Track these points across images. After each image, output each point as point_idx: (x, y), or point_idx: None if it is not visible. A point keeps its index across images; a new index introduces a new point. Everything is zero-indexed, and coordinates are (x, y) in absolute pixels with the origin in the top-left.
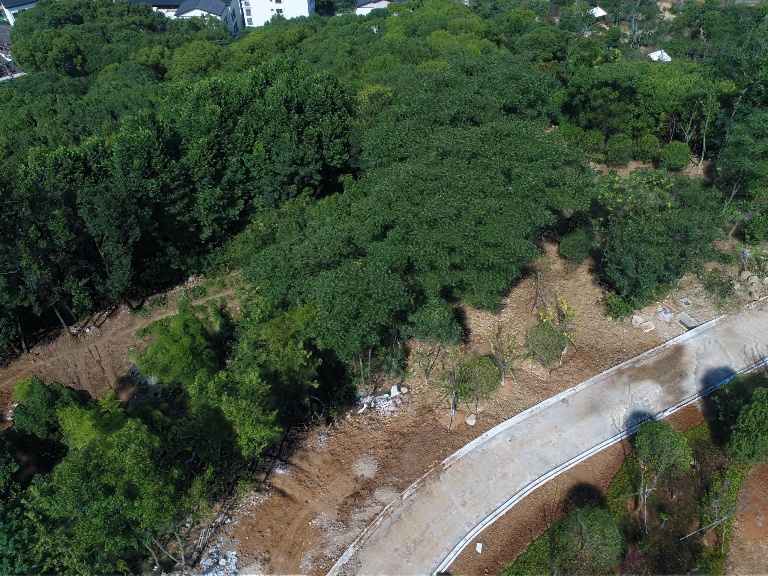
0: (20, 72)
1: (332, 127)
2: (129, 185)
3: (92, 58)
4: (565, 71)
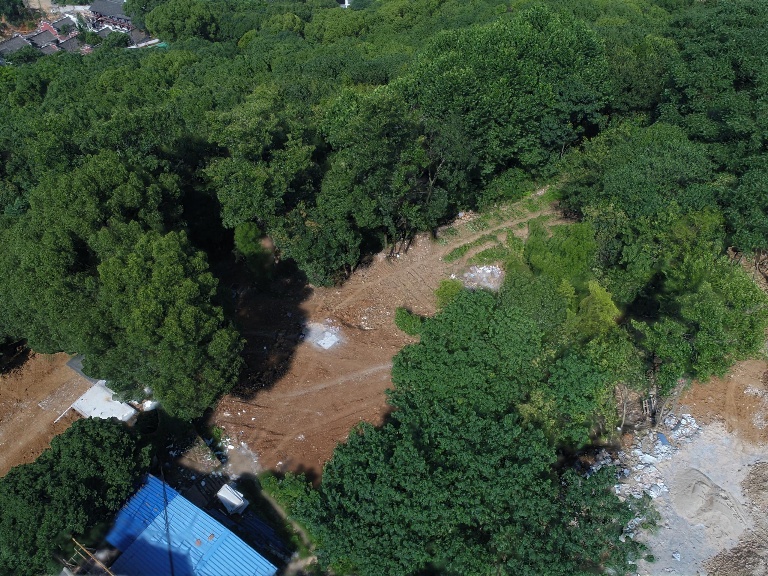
0: (145, 42)
1: (599, 70)
2: None
3: (225, 26)
4: None
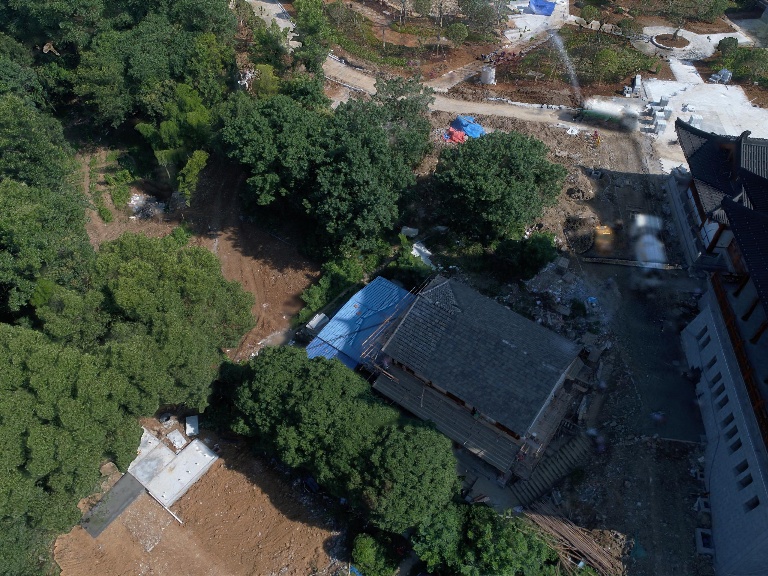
0: None
1: None
2: None
3: None
4: None
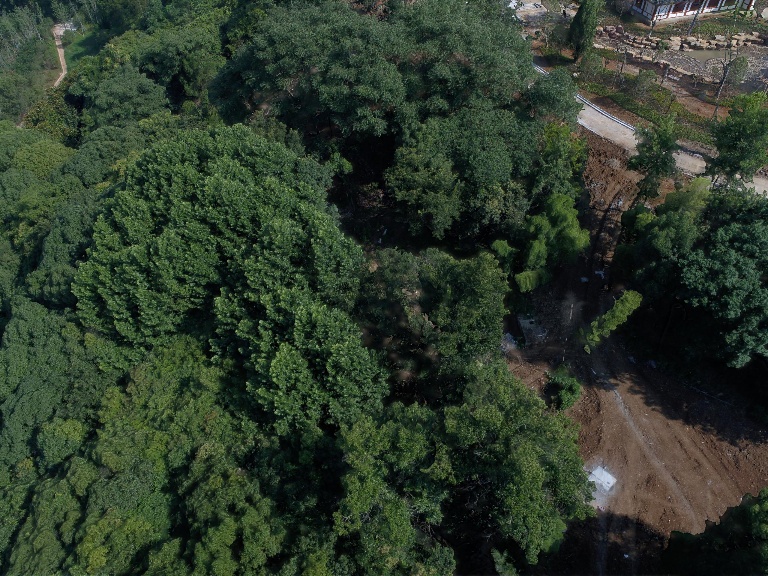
0: None
1: None
2: (345, 279)
3: None
4: (83, 92)
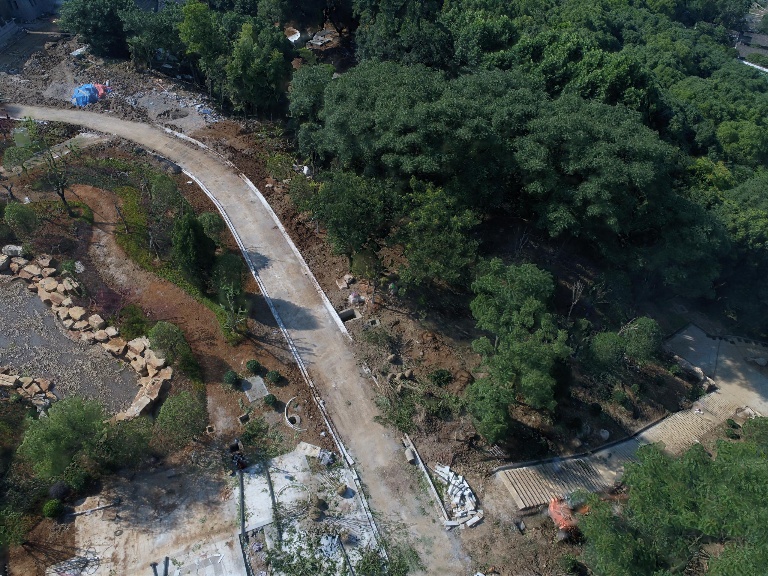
0: None
1: None
2: None
3: None
4: None
